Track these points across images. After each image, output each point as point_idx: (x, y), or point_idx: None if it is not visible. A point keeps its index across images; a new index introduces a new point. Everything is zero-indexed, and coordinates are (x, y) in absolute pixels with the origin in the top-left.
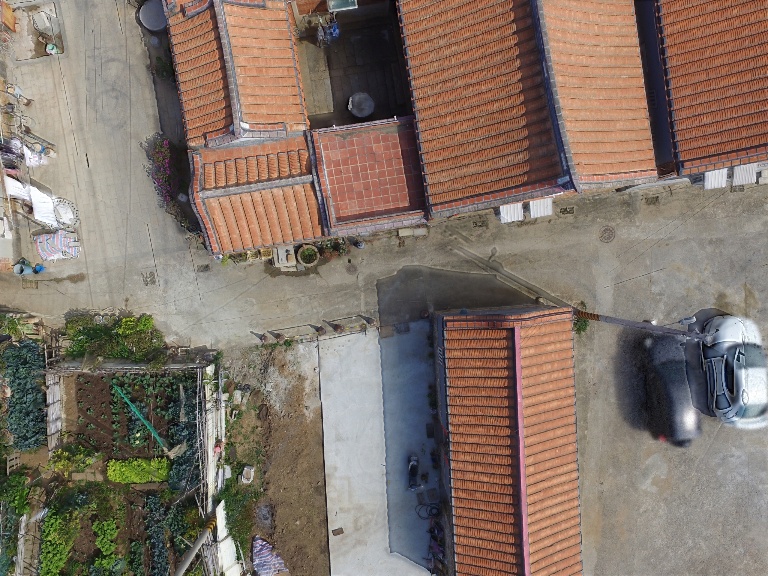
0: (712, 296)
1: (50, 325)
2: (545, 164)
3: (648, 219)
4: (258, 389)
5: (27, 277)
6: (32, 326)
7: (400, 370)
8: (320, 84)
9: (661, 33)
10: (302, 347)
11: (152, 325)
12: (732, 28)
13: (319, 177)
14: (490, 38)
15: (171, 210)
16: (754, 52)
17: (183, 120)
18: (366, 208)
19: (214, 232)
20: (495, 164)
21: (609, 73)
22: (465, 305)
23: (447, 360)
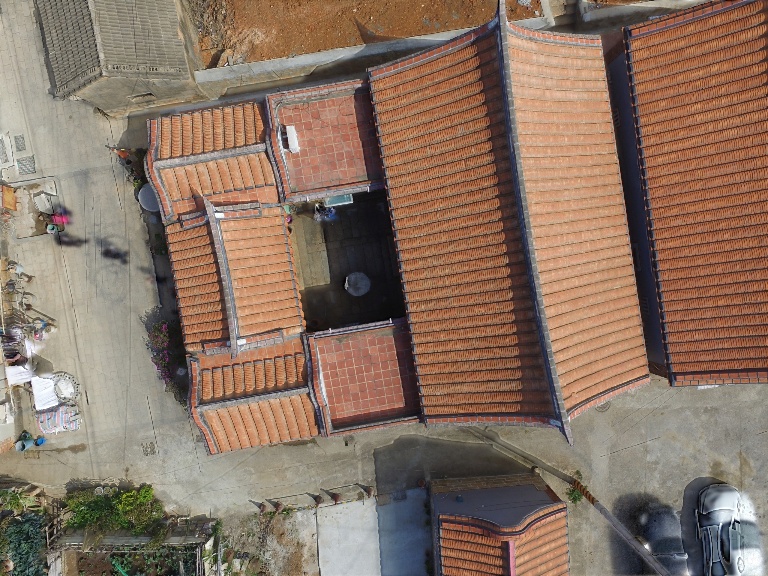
0: (707, 465)
1: (52, 495)
2: (538, 399)
3: (643, 388)
4: (257, 557)
5: (29, 448)
6: (34, 498)
7: (397, 537)
8: (317, 256)
9: (653, 247)
10: (300, 514)
11: (152, 496)
12: (723, 251)
13: (315, 392)
14: (483, 265)
15: (170, 391)
16: (745, 277)
17: (181, 324)
18: (362, 410)
19: (212, 436)
20: (489, 387)
21: (602, 288)
22: (462, 474)
23: (443, 558)
